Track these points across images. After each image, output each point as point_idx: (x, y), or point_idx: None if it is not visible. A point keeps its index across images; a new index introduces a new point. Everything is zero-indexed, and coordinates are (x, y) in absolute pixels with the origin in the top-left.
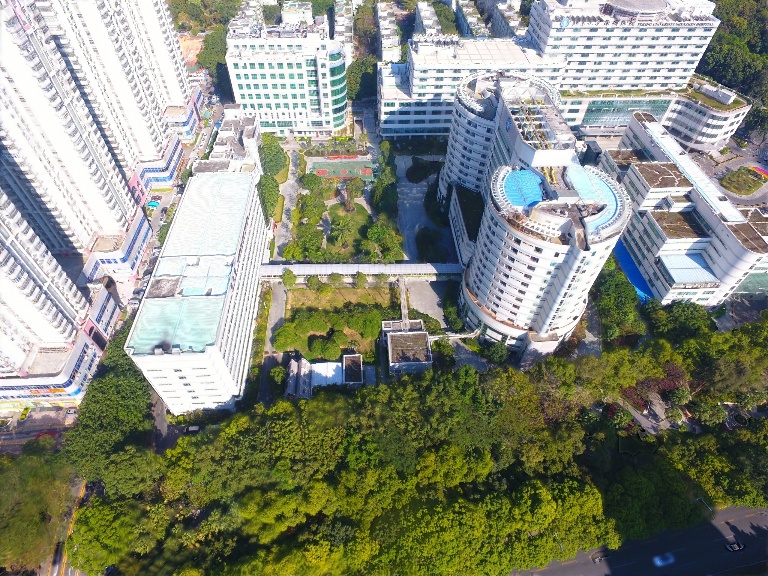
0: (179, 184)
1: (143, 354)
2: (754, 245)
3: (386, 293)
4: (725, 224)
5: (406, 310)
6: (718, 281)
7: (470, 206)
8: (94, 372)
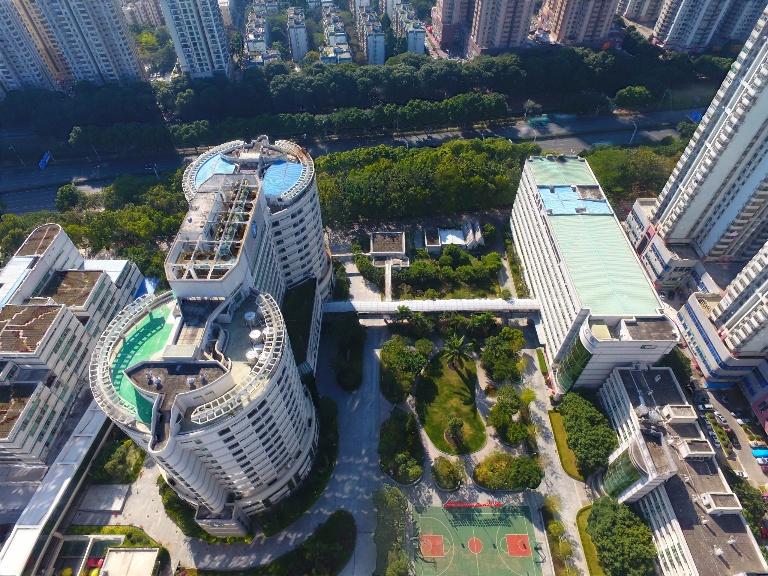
0: (766, 513)
1: (570, 156)
2: (47, 233)
3: (405, 284)
4: (44, 253)
5: (387, 273)
6: (86, 260)
7: (297, 327)
8: (630, 238)
